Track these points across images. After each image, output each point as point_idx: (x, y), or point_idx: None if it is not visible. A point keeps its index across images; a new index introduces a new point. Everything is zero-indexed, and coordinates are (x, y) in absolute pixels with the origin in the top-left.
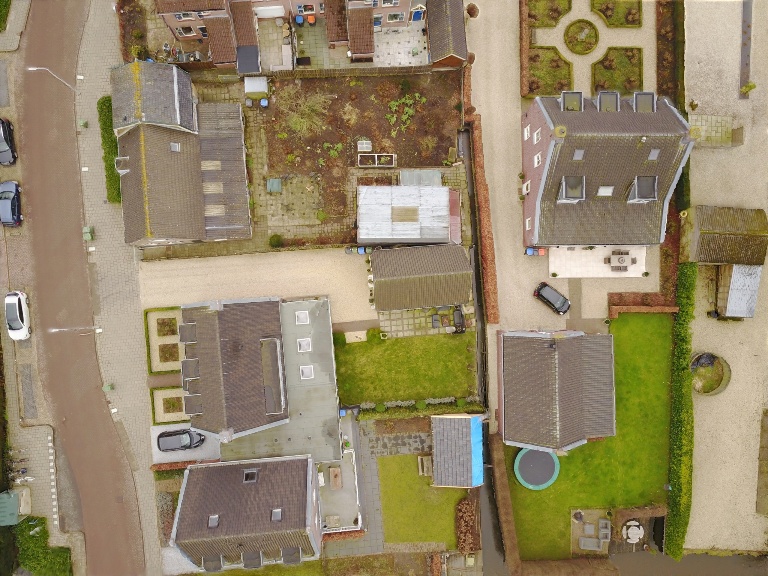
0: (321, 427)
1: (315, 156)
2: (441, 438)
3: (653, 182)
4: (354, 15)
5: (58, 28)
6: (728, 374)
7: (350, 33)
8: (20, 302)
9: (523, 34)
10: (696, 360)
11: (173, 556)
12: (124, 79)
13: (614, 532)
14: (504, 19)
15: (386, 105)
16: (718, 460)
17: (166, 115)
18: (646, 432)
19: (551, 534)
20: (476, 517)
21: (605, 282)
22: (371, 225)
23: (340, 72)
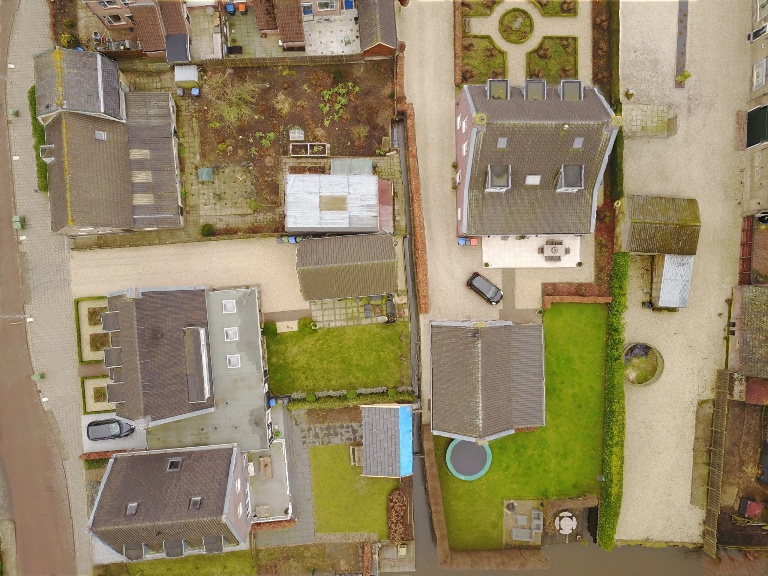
0: (248, 416)
1: (247, 145)
2: (370, 428)
3: (580, 171)
4: (281, 3)
5: None
6: (661, 365)
7: (278, 21)
8: None
9: (456, 23)
10: (630, 351)
11: (103, 545)
12: (47, 67)
13: (547, 523)
14: (438, 8)
15: (319, 94)
16: (653, 451)
17: (89, 103)
18: (579, 423)
19: (483, 525)
20: (408, 507)
21: (539, 272)
22: (299, 214)
23: (271, 61)
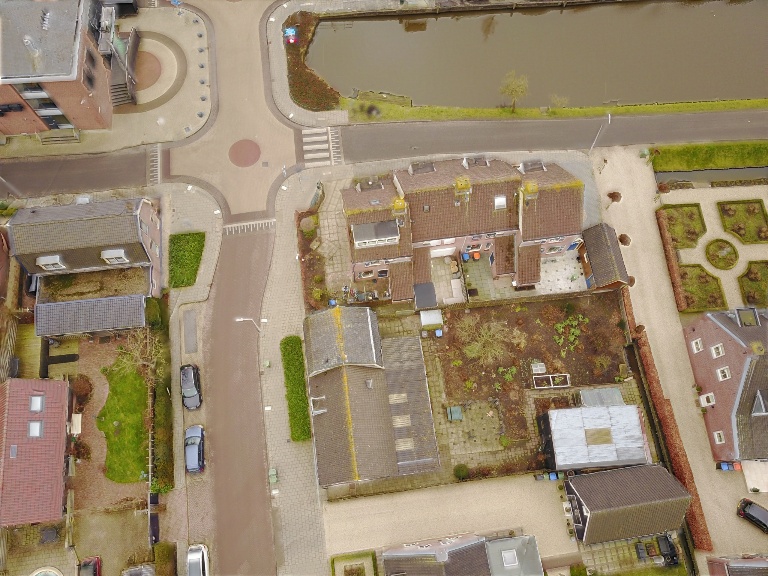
0: None
1: (490, 381)
2: None
3: None
4: (524, 252)
5: (245, 278)
6: None
7: (519, 267)
8: (203, 556)
9: (671, 256)
10: None
11: None
12: (324, 324)
13: None
14: (648, 243)
15: (552, 327)
16: None
17: (364, 355)
18: None
19: None
20: None
21: None
22: (567, 450)
23: (509, 301)
